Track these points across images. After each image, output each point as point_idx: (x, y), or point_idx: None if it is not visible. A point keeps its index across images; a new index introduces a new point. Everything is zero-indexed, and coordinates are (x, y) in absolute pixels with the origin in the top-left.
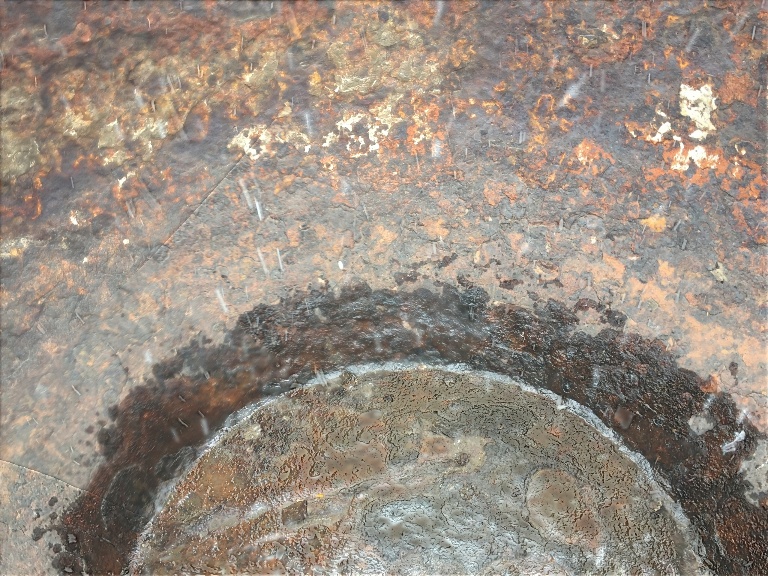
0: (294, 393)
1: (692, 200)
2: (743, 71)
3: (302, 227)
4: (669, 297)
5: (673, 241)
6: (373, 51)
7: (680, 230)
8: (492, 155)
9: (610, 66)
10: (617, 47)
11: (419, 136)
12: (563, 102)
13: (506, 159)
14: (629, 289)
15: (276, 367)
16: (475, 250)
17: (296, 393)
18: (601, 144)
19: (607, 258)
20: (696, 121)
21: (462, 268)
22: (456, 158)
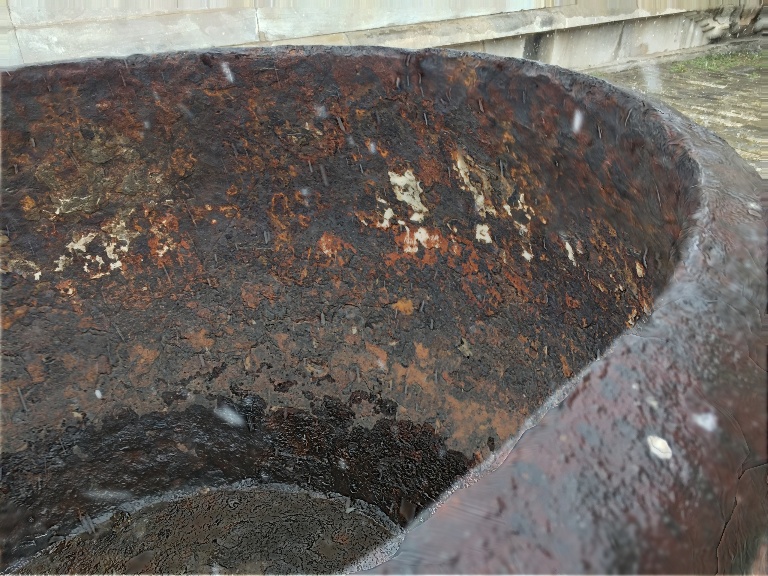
0: (53, 548)
1: (428, 280)
2: (431, 155)
3: (46, 360)
4: (429, 378)
5: (422, 322)
6: (87, 169)
7: (425, 310)
8: (242, 258)
9: (325, 161)
10: (324, 142)
11: (162, 248)
12: (295, 199)
13: (257, 260)
14: (394, 375)
15: (29, 522)
16: (244, 356)
17: (56, 548)
18: (340, 235)
19: (369, 347)
20: (411, 205)
21: (234, 377)
22: (207, 265)
